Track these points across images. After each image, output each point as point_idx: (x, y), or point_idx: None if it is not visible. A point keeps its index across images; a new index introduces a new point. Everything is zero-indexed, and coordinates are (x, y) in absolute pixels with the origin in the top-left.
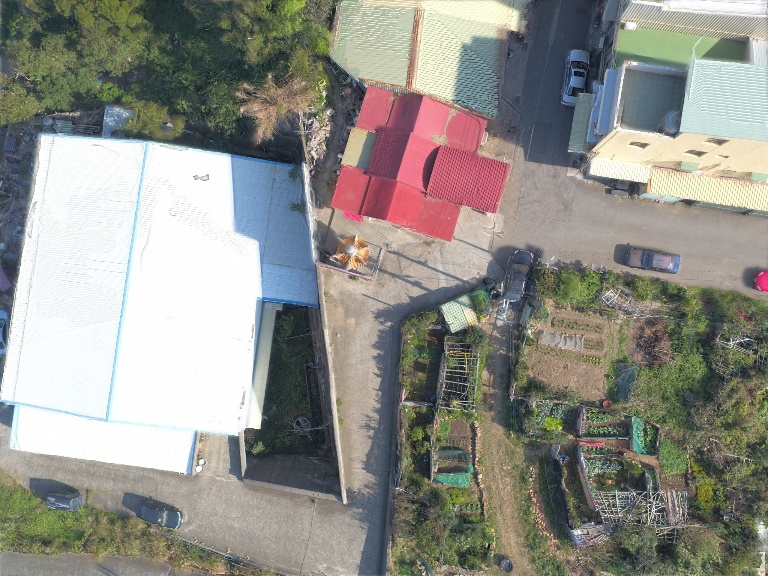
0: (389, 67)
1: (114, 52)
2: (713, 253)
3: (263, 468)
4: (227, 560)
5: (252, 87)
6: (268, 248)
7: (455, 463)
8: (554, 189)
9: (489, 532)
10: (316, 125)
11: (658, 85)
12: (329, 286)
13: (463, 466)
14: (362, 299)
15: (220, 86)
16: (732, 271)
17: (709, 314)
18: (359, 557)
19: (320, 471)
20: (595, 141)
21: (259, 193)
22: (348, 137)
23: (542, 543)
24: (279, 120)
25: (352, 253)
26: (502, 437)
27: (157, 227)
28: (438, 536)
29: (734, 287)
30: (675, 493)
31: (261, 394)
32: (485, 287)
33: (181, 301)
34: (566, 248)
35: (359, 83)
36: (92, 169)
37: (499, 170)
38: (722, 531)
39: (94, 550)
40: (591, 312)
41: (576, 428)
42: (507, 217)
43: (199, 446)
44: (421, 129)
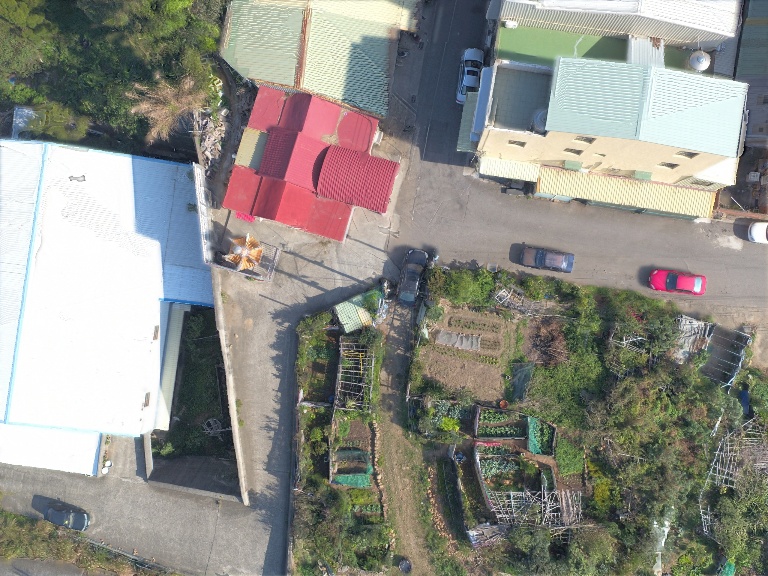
0: (278, 67)
1: (19, 53)
2: (608, 252)
3: (170, 469)
4: (133, 562)
5: (145, 87)
6: (170, 249)
7: (355, 464)
8: (450, 188)
9: (389, 533)
10: (210, 125)
11: (532, 83)
12: (226, 287)
13: (363, 467)
14: (259, 300)
15: (117, 87)
16: (627, 270)
17: (603, 313)
18: (263, 558)
19: (227, 472)
20: (477, 140)
21: (162, 194)
22: (241, 137)
23: (441, 544)
24: (175, 120)
25: (241, 253)
26: (401, 437)
27: (49, 228)
28: (333, 537)
29: (629, 286)
30: (569, 493)
31: (169, 395)
32: (379, 287)
33: (80, 302)
34: (462, 247)
35: (252, 83)
36: (1, 170)
37: (388, 169)
38: (615, 531)
39: (2, 552)
40: (488, 312)
41: (473, 428)
42: (403, 217)
43: (105, 448)
44: (309, 129)
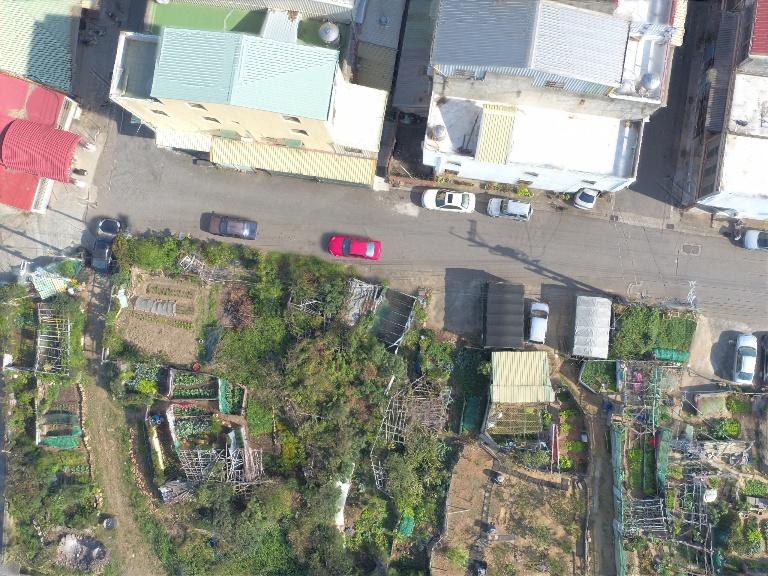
0: None
1: None
2: (293, 220)
3: None
4: None
5: None
6: None
7: (64, 426)
8: (145, 160)
9: (96, 492)
10: None
11: None
12: None
13: (72, 429)
14: None
15: None
16: (310, 237)
17: (285, 278)
18: None
19: None
20: None
21: None
22: None
23: (142, 502)
24: None
25: None
26: (106, 400)
27: None
28: (32, 495)
29: (312, 252)
30: (252, 451)
31: None
32: None
33: None
34: (155, 217)
35: None
36: None
37: (67, 141)
38: (292, 486)
39: None
40: (183, 278)
41: None
42: (100, 188)
43: None
44: None
